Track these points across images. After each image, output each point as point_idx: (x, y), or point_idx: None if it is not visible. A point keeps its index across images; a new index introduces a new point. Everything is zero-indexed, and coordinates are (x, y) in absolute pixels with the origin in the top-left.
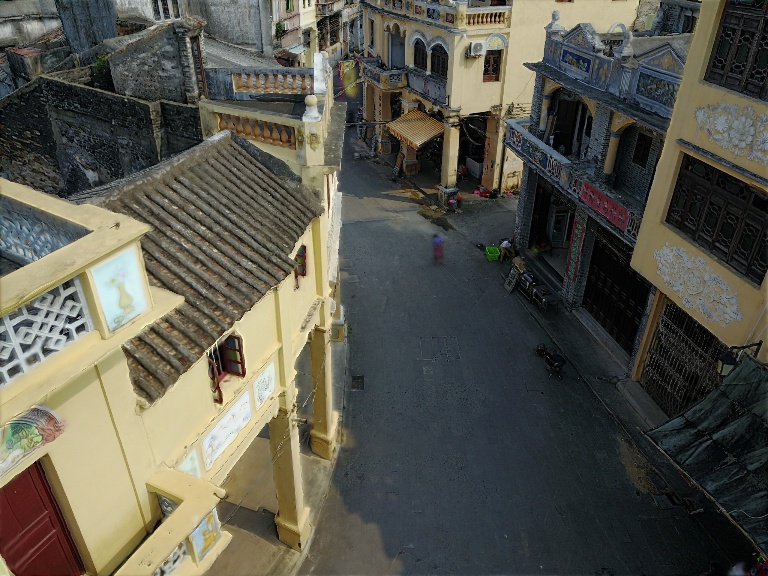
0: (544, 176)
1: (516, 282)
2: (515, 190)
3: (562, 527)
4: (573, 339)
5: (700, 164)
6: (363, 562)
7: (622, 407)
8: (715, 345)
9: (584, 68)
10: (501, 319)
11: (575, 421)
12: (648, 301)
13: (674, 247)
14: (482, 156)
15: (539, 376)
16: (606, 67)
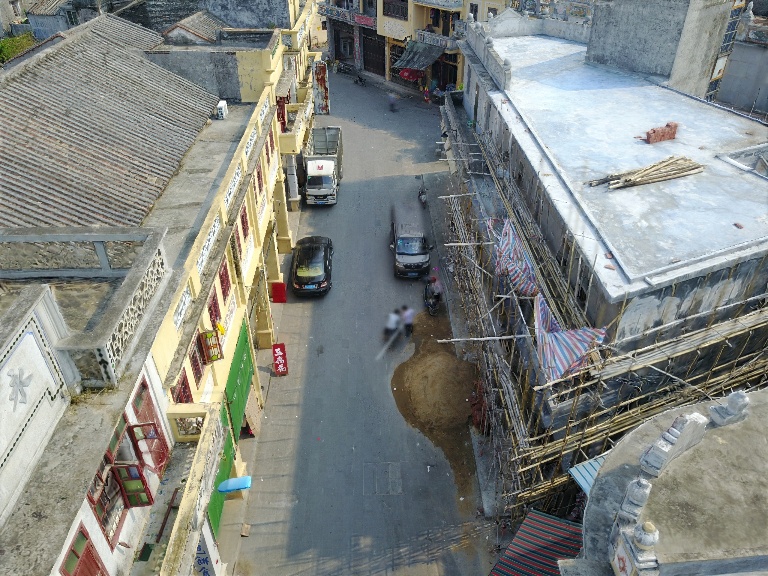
0: (340, 19)
1: (338, 68)
2: (317, 46)
3: (379, 106)
4: (365, 78)
5: None
6: None
7: None
8: None
9: None
10: (337, 79)
11: (374, 92)
12: (385, 50)
13: (387, 21)
14: None
15: (358, 87)
16: None
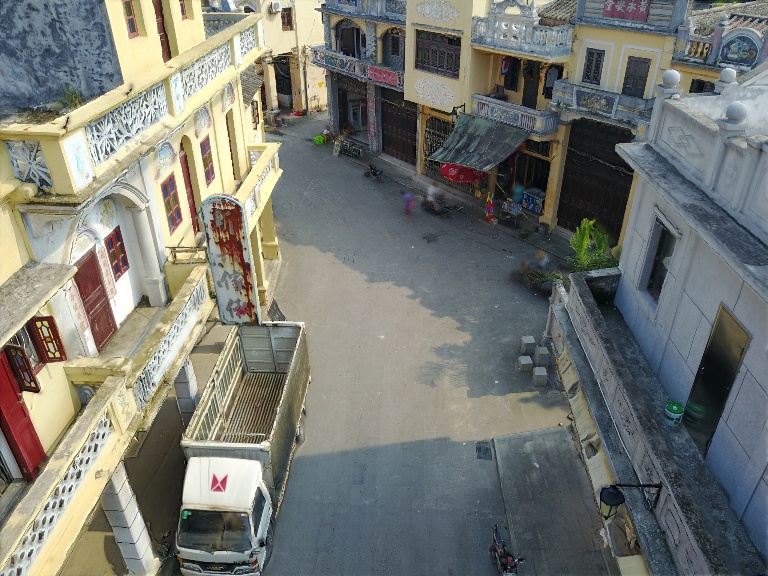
0: (344, 73)
1: (340, 148)
2: (318, 109)
3: (402, 226)
4: (382, 167)
5: (424, 33)
6: (312, 256)
7: (417, 185)
8: (451, 129)
9: (353, 4)
10: (338, 167)
11: (395, 195)
12: (417, 124)
13: (422, 78)
14: (288, 91)
15: (370, 184)
16: (366, 1)
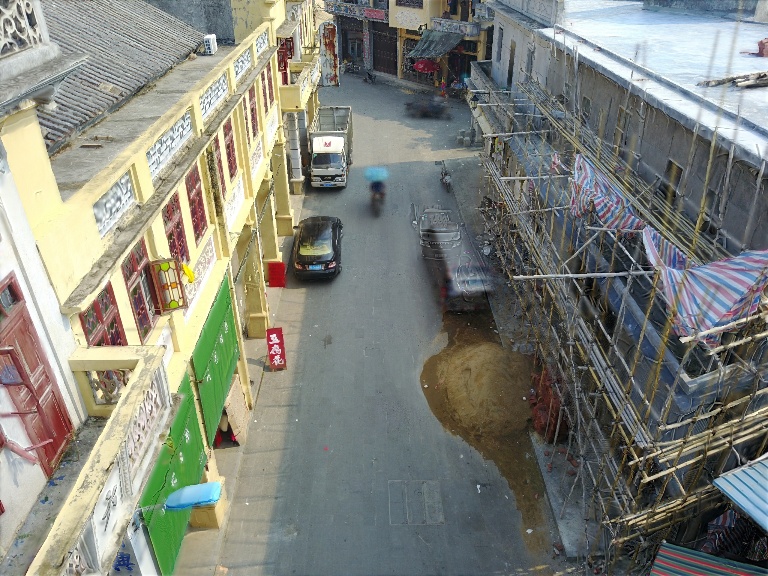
0: (348, 15)
1: (345, 68)
2: None
3: (391, 100)
4: None
5: None
6: None
7: None
8: None
9: None
10: None
11: (385, 89)
12: (397, 45)
13: (400, 11)
14: None
15: (368, 85)
16: None
